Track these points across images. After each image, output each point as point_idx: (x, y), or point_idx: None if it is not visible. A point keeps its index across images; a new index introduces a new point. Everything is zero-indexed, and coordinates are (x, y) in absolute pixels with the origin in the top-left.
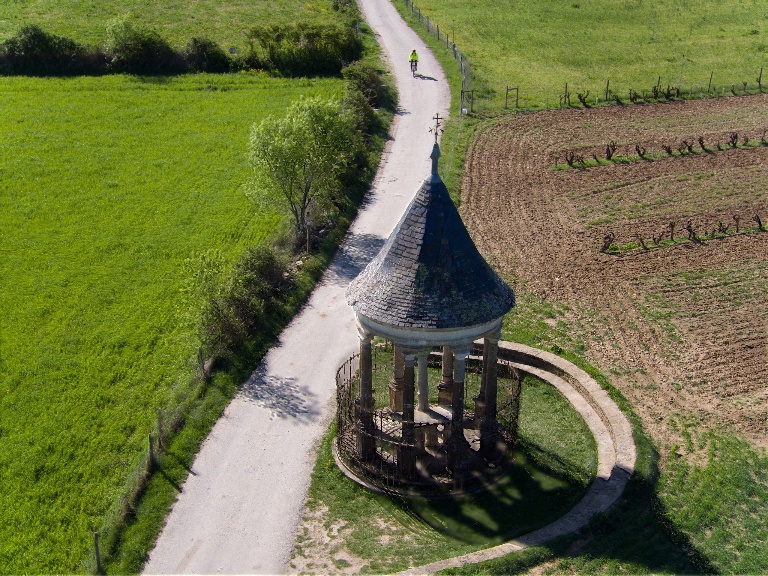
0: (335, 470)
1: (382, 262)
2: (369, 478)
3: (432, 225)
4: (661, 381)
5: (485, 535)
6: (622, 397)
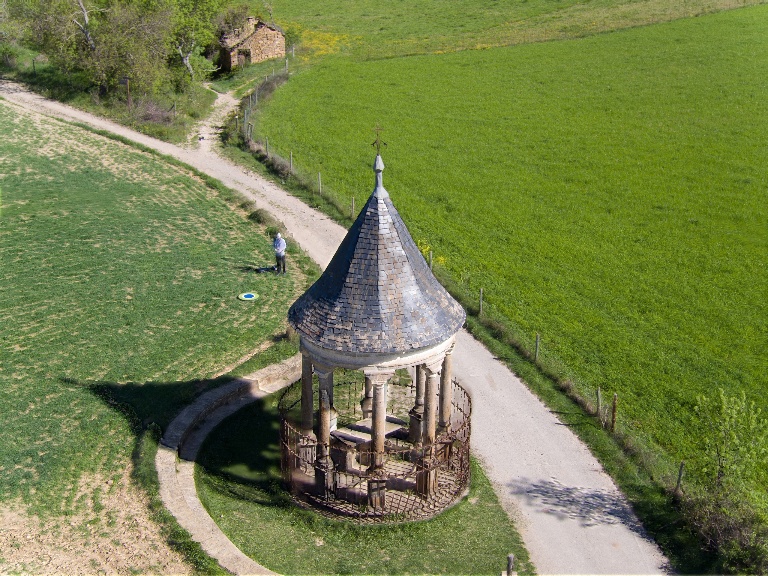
0: None
1: None
2: None
3: None
4: None
5: None
6: (174, 534)
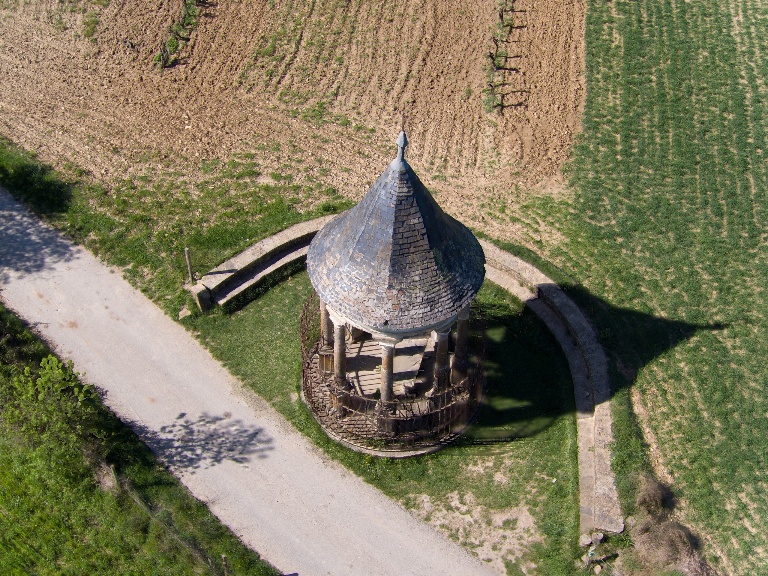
0: (379, 461)
1: (389, 270)
2: (417, 444)
3: (424, 209)
4: (426, 181)
5: (544, 411)
6: None
